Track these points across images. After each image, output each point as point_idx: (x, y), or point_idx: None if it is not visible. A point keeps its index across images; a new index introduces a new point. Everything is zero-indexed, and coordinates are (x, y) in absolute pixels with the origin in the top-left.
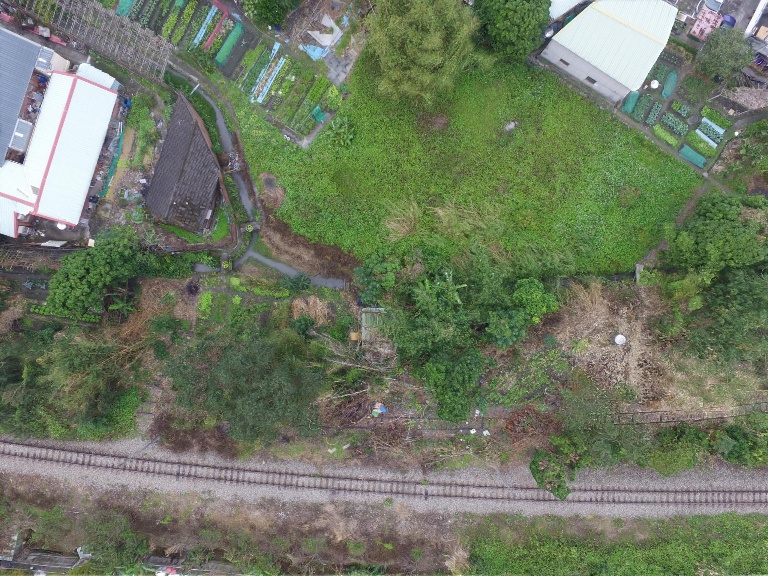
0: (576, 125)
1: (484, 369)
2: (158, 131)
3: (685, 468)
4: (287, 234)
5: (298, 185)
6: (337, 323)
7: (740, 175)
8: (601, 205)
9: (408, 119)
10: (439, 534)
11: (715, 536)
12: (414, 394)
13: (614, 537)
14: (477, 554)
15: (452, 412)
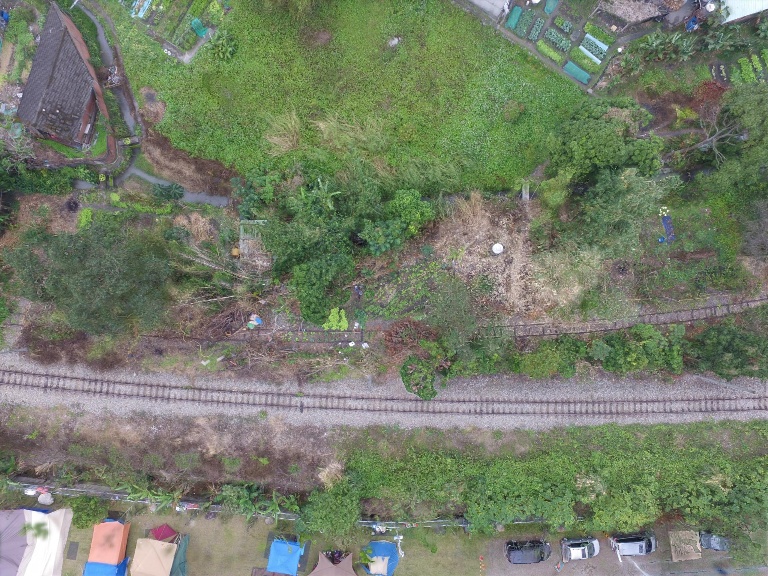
0: (459, 41)
1: (360, 278)
2: (36, 45)
3: (566, 379)
4: (166, 148)
5: (178, 98)
6: (219, 240)
7: (624, 91)
8: (486, 121)
9: (290, 34)
10: (316, 448)
11: (596, 448)
12: (291, 306)
13: (494, 450)
14: (353, 467)
15: (310, 308)
